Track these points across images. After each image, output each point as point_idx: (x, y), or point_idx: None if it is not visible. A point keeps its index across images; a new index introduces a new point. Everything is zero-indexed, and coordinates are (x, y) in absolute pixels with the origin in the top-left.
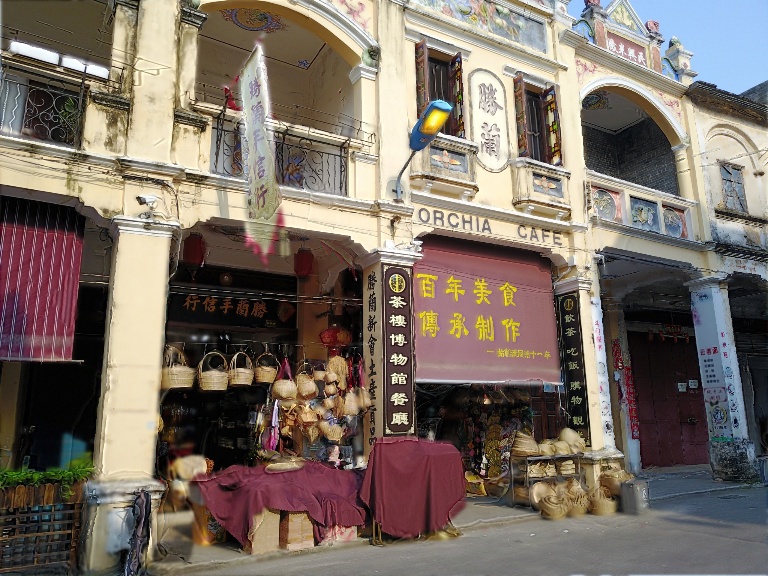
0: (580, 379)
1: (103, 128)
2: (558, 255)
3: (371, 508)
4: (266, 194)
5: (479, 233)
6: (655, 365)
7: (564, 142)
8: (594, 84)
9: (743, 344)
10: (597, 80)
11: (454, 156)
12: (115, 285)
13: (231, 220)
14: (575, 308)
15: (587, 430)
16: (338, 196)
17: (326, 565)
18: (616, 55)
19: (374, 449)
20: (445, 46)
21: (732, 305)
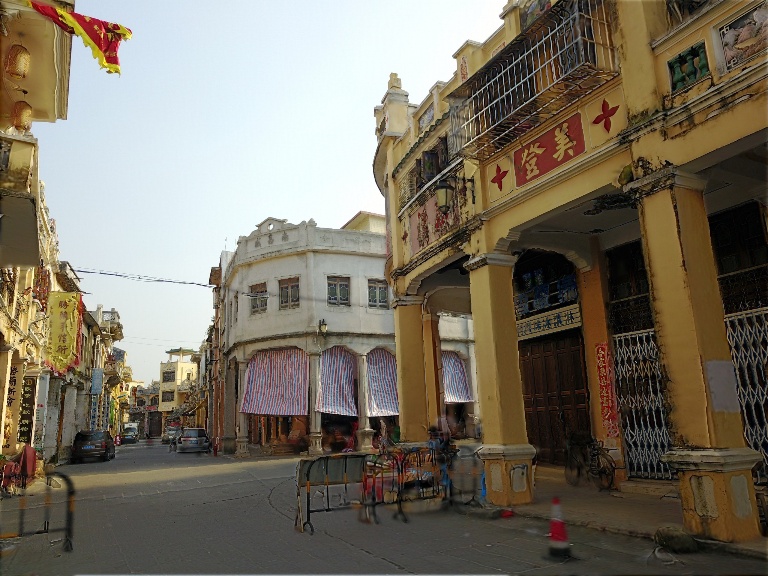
0: (29, 419)
1: (6, 302)
2: (33, 358)
3: (22, 473)
4: (67, 350)
5: None
6: None
7: None
8: None
9: None
10: None
11: (36, 312)
12: (6, 376)
13: None
14: (33, 385)
15: (29, 443)
16: None
17: (40, 489)
18: (55, 256)
19: (25, 448)
20: None
21: None
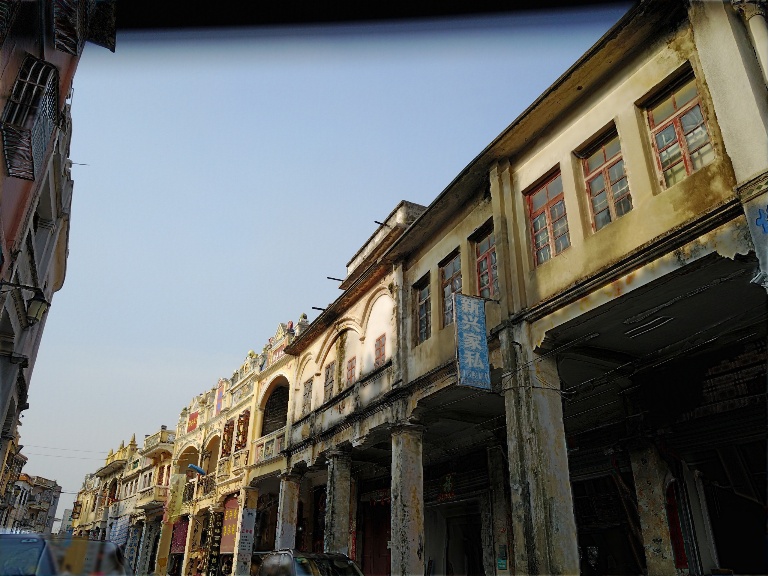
0: None
1: None
2: None
3: None
4: None
5: (227, 491)
6: (376, 527)
7: (248, 433)
8: (264, 390)
9: (425, 494)
10: (264, 387)
11: None
12: None
13: (201, 509)
14: None
15: None
16: (208, 494)
17: None
18: None
19: None
20: (231, 419)
21: (423, 454)
